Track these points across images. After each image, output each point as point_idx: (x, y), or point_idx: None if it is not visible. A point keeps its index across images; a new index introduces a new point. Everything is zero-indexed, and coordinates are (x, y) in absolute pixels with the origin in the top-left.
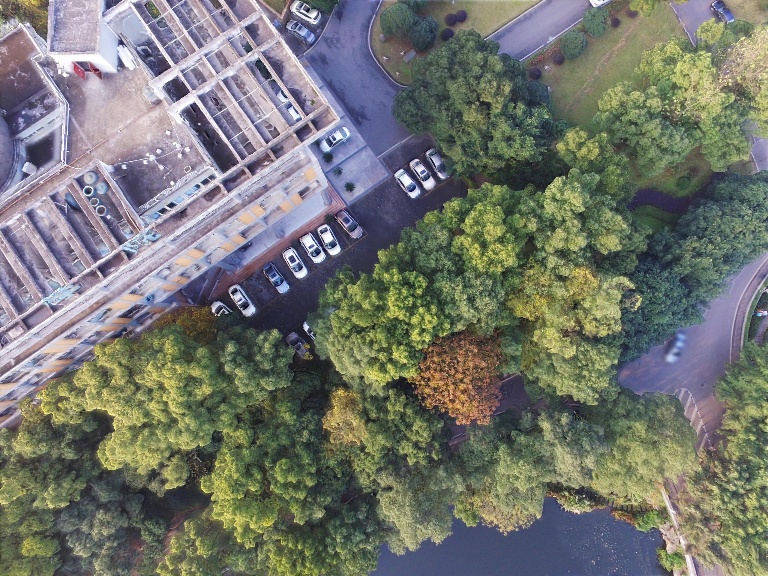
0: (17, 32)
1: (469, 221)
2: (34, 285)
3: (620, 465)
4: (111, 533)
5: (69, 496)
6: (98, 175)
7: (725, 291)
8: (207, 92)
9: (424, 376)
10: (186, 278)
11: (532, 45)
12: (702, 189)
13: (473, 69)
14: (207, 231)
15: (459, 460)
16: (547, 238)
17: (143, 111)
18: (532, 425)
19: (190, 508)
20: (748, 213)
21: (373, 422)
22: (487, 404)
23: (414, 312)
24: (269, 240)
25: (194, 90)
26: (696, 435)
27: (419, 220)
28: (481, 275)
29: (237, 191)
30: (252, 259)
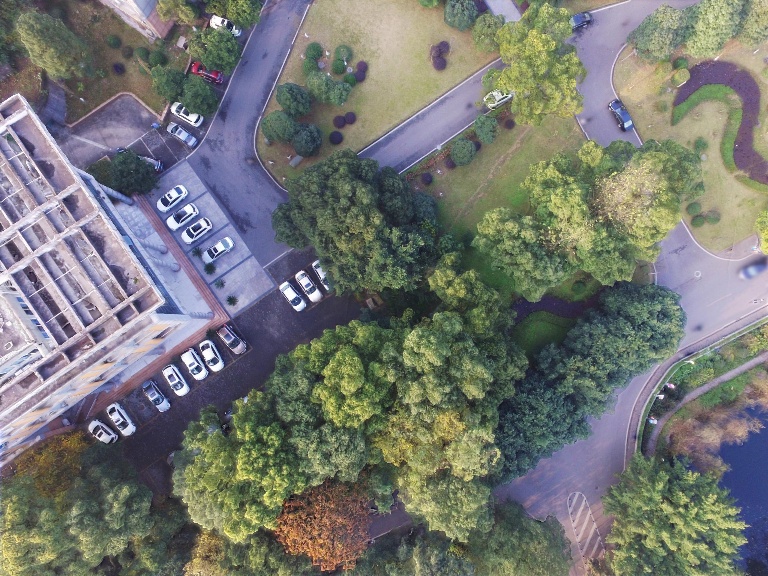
0: None
1: (327, 372)
2: None
3: None
4: None
5: None
6: None
7: (611, 407)
8: (24, 269)
9: (283, 529)
10: (40, 423)
11: (425, 148)
12: (597, 294)
13: (341, 201)
14: (43, 396)
15: None
16: (408, 387)
17: None
18: (407, 557)
19: None
20: (631, 333)
21: (236, 569)
22: (353, 549)
23: (267, 471)
24: (149, 356)
25: (6, 270)
26: (566, 570)
27: (291, 351)
28: (338, 429)
29: (54, 378)
30: (132, 376)
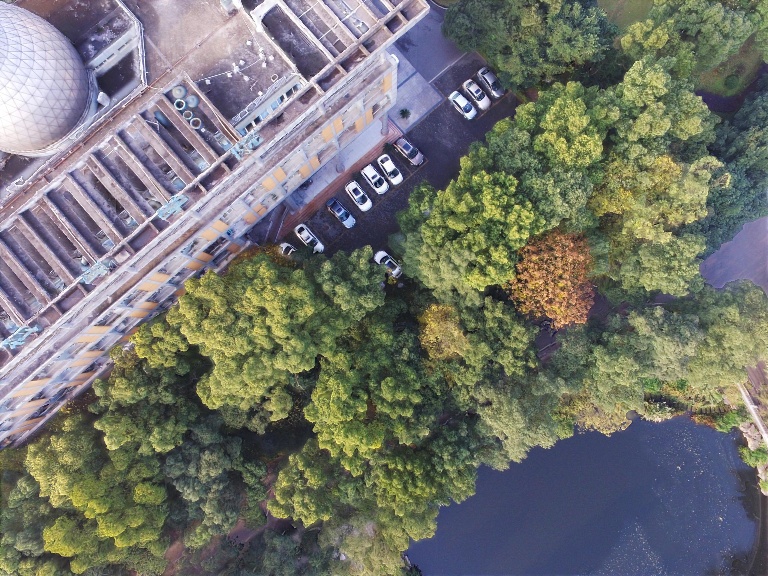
0: None
1: (551, 117)
2: (136, 206)
3: (716, 352)
4: (216, 475)
5: (172, 440)
6: (187, 89)
7: None
8: None
9: (521, 278)
10: (265, 209)
11: None
12: (751, 86)
13: None
14: (293, 147)
15: (553, 368)
16: (629, 127)
17: (220, 24)
18: (622, 325)
19: (278, 456)
20: None
21: (471, 333)
22: (583, 303)
23: (508, 211)
24: (329, 176)
25: None
26: None
27: (489, 131)
28: (569, 169)
29: (333, 90)
30: (314, 197)
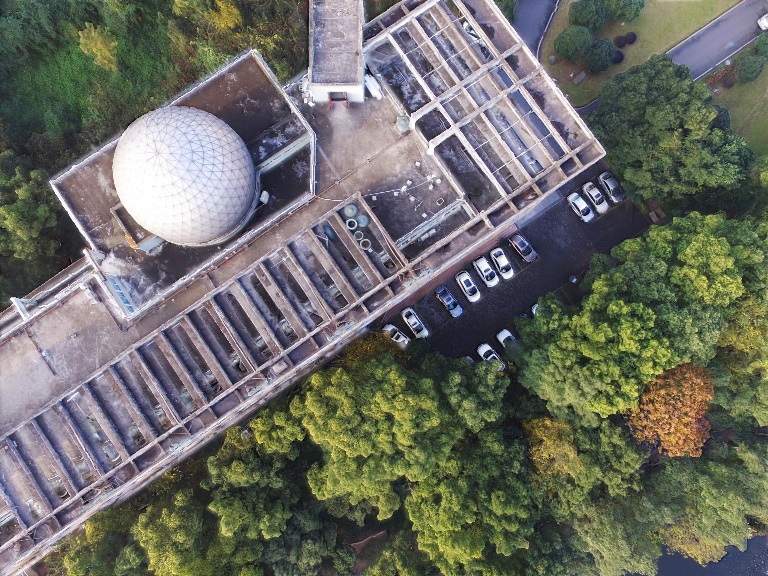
0: (245, 58)
1: (692, 252)
2: (299, 319)
3: None
4: None
5: (278, 526)
6: (358, 208)
7: None
8: (466, 124)
9: (644, 408)
10: (392, 305)
11: (701, 68)
12: None
13: (680, 96)
14: None
15: (653, 490)
16: None
17: (391, 142)
18: (729, 456)
19: None
20: None
21: (584, 453)
22: (700, 436)
23: (643, 345)
24: None
25: (458, 123)
26: None
27: (615, 247)
28: (707, 307)
29: None
30: None
